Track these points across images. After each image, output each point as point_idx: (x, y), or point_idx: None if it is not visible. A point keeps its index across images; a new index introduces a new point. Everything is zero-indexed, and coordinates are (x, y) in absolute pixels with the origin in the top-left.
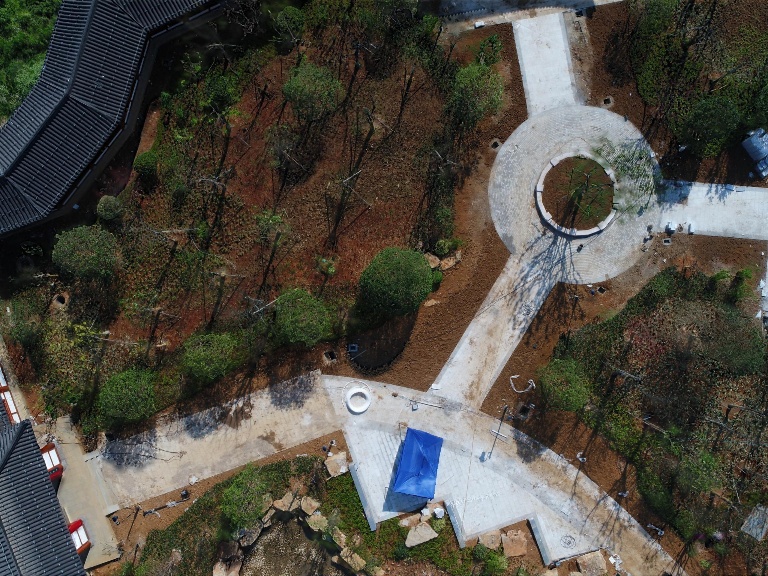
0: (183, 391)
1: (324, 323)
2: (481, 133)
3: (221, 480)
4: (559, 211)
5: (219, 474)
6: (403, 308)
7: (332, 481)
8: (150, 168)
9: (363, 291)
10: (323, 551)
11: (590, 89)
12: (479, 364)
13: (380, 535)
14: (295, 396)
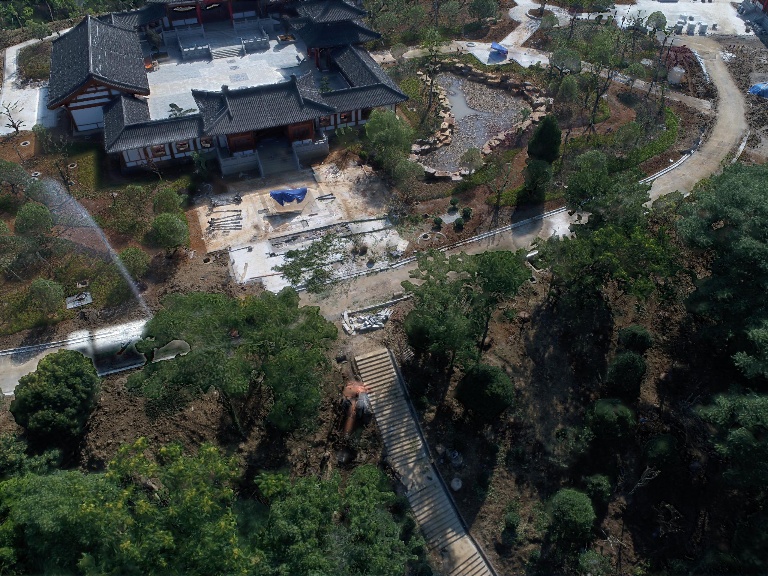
0: (402, 39)
1: (459, 5)
2: (503, 6)
3: (418, 58)
4: (536, 15)
5: (417, 57)
6: (486, 6)
7: (464, 55)
8: (390, 2)
9: (470, 9)
10: (463, 78)
11: (538, 2)
12: (517, 39)
13: (487, 67)
14: (445, 44)
